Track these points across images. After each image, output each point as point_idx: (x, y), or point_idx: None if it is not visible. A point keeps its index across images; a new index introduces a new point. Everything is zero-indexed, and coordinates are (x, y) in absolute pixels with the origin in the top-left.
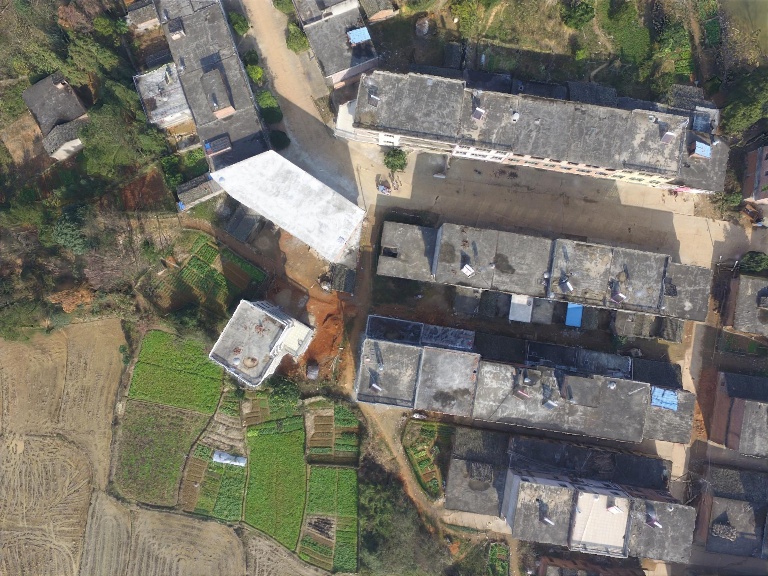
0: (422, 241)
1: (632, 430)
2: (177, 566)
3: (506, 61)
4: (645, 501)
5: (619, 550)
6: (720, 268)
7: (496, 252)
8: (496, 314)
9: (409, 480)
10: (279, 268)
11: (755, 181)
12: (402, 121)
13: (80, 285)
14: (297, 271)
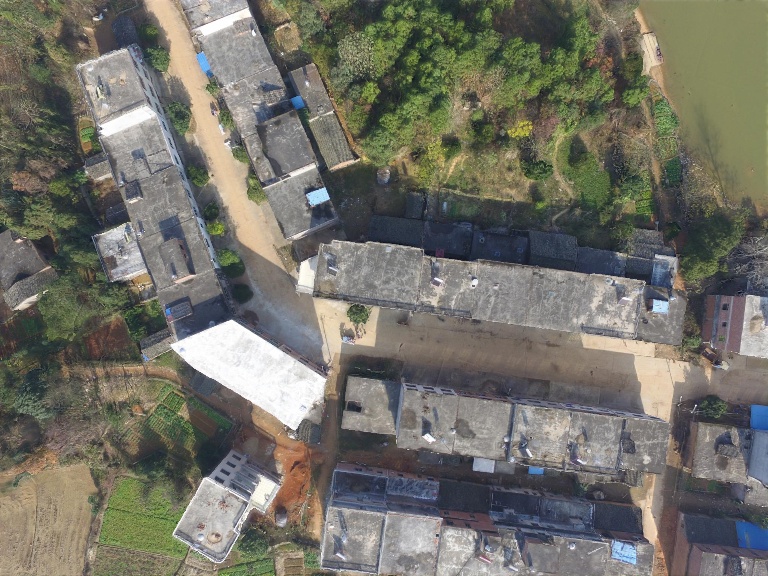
0: (386, 395)
1: None
2: None
3: (468, 207)
4: None
5: None
6: (680, 408)
7: (457, 417)
8: (461, 462)
9: None
10: (246, 416)
11: (713, 328)
12: (361, 289)
13: (46, 440)
14: (264, 419)
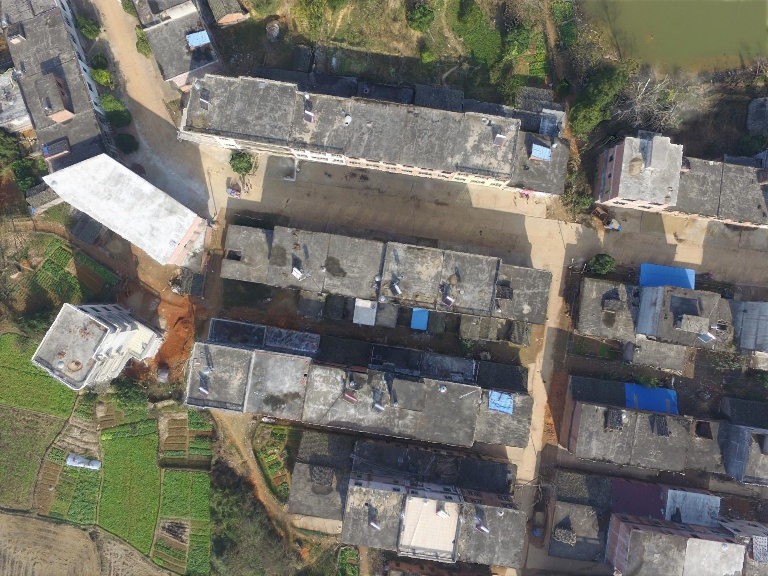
0: (266, 244)
1: (463, 434)
2: (33, 570)
3: (357, 64)
4: (475, 505)
5: (449, 555)
6: (572, 271)
7: (327, 255)
8: (343, 317)
9: (260, 484)
10: (131, 271)
11: (601, 183)
12: (234, 124)
13: None
14: (149, 274)
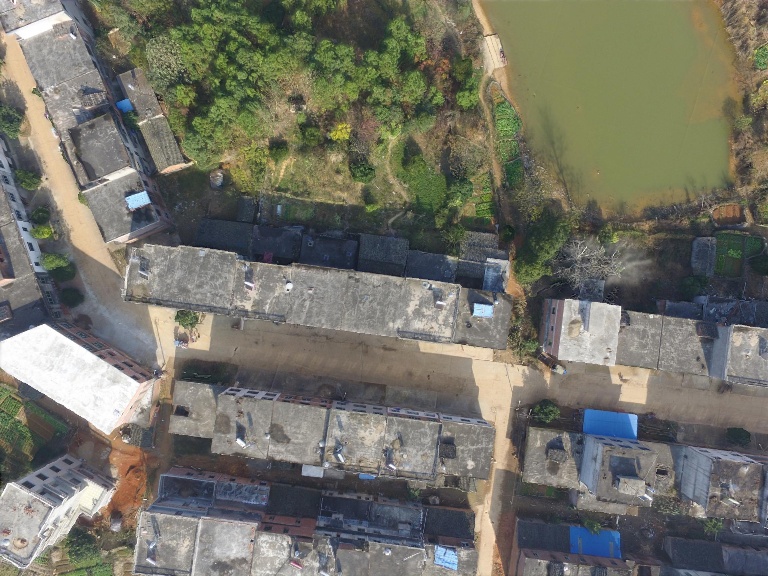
0: (213, 399)
1: None
2: None
3: (303, 210)
4: None
5: None
6: (519, 413)
7: (271, 422)
8: (293, 467)
9: None
10: (82, 420)
11: (545, 332)
12: (174, 293)
13: None
14: None
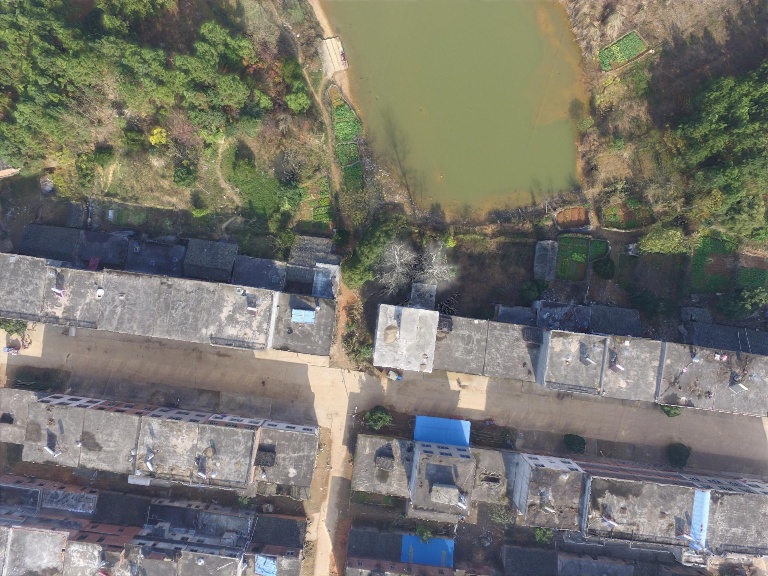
0: None
1: None
2: None
3: (135, 215)
4: None
5: None
6: (355, 419)
7: (83, 430)
8: (123, 474)
9: None
10: None
11: (375, 338)
12: None
13: None
14: None
